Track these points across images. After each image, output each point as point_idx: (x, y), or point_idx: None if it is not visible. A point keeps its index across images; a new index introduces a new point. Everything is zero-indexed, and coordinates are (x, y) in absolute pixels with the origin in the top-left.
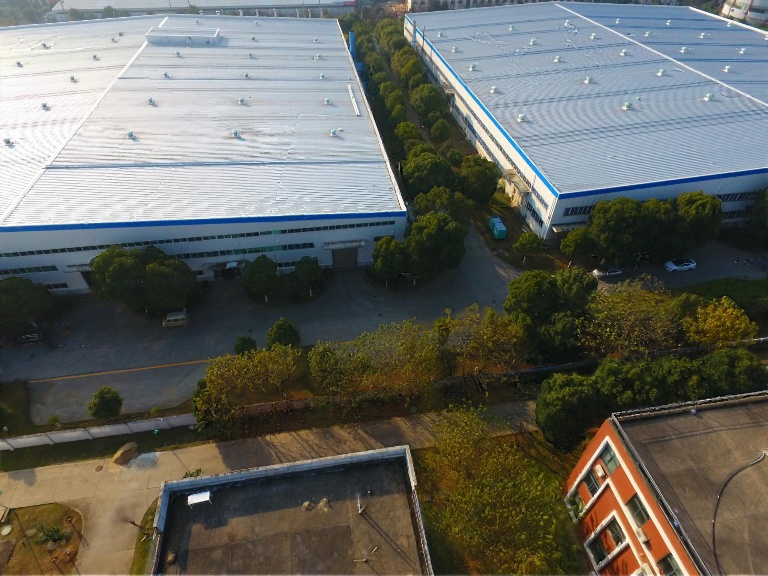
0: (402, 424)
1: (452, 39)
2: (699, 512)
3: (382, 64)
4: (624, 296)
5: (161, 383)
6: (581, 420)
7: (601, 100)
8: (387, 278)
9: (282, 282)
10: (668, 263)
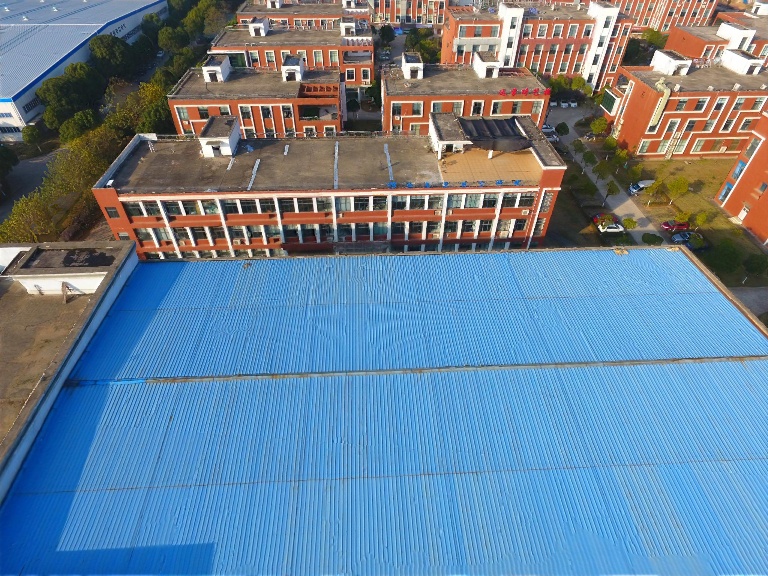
0: None
1: None
2: (211, 96)
3: None
4: None
5: None
6: None
7: None
8: None
9: None
10: None
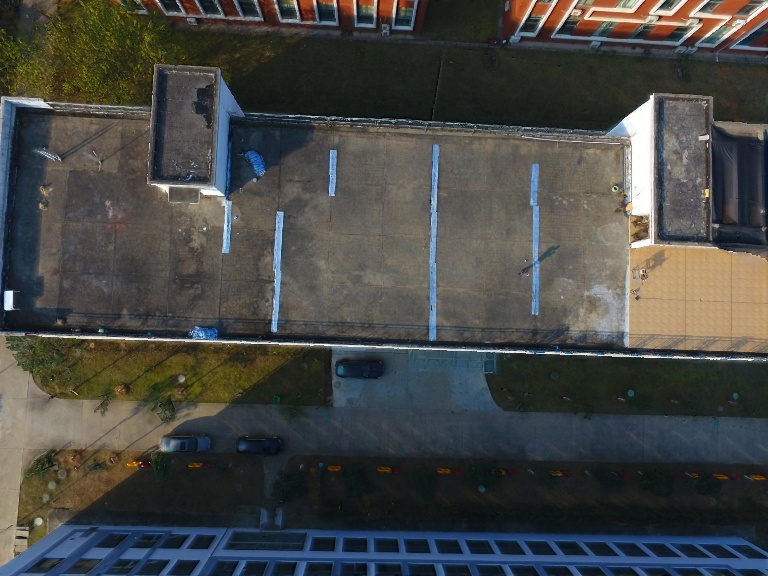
0: None
1: None
2: None
3: None
4: None
5: None
6: None
7: None
8: None
9: None
10: None
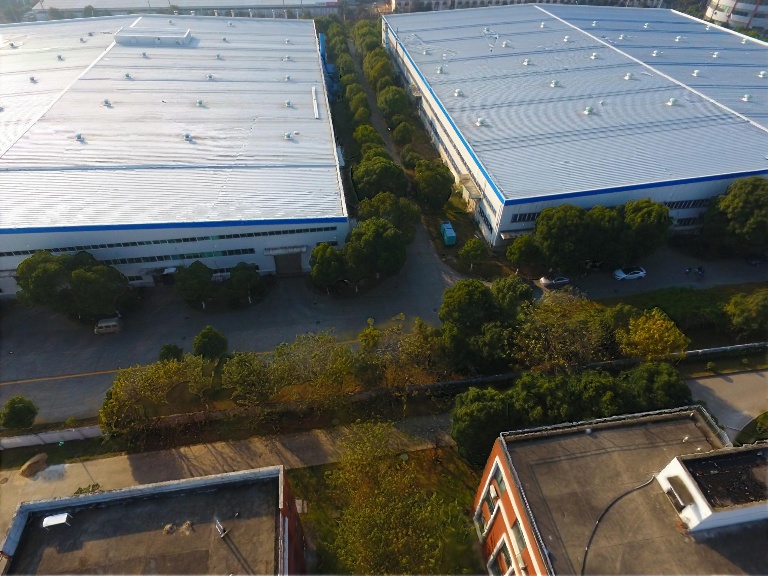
0: (321, 436)
1: (425, 41)
2: (574, 539)
3: (352, 66)
4: (553, 307)
5: (84, 392)
6: (492, 436)
7: (564, 104)
8: (324, 285)
9: (219, 288)
10: (617, 271)
